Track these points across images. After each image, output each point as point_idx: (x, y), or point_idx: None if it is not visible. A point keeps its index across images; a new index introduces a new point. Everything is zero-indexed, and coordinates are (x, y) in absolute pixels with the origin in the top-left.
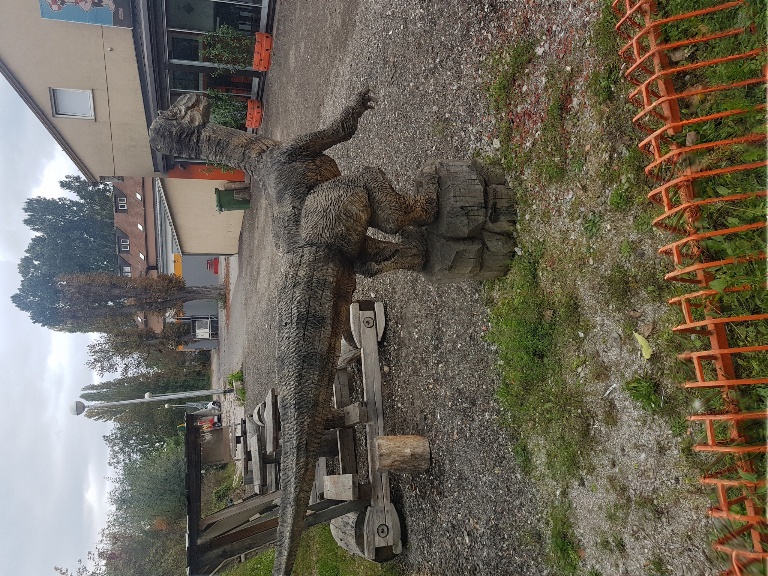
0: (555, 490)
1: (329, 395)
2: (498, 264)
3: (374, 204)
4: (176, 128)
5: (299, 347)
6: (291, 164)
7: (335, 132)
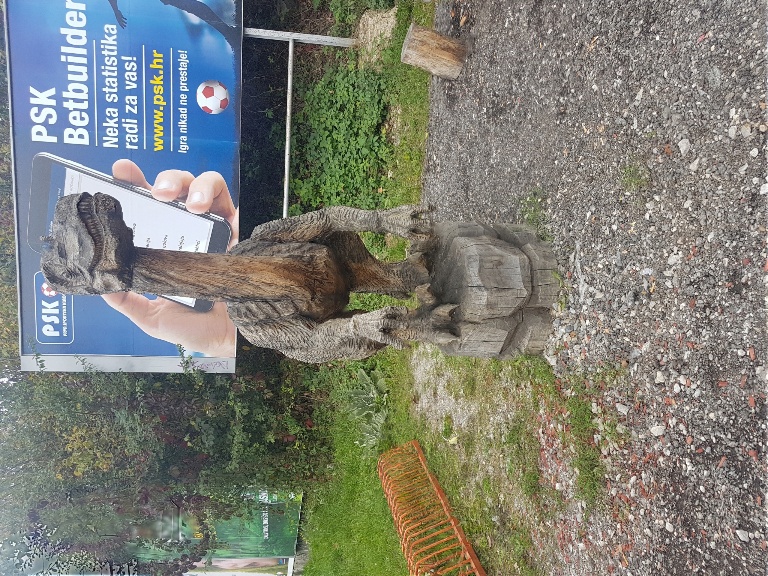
0: None
1: None
2: None
3: None
4: None
5: None
6: None
7: None
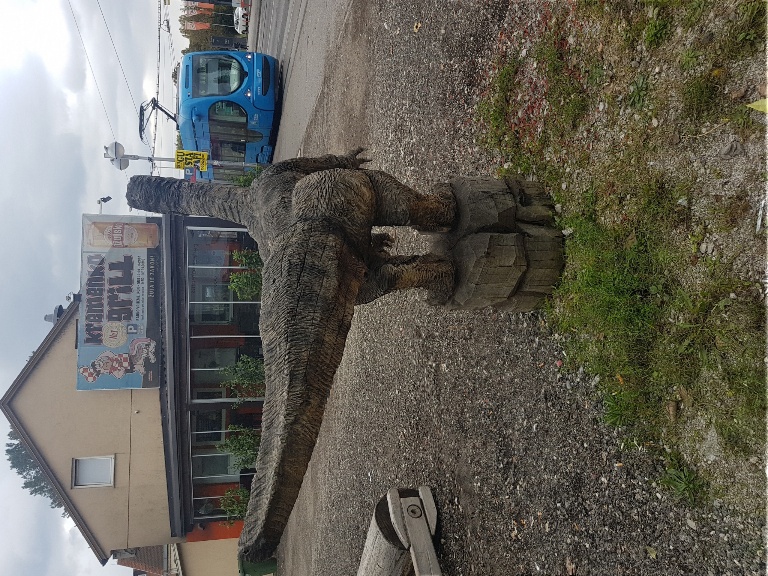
0: (761, 475)
1: (341, 343)
2: (548, 256)
3: (378, 188)
4: (156, 177)
5: (292, 289)
6: (280, 174)
7: (328, 160)
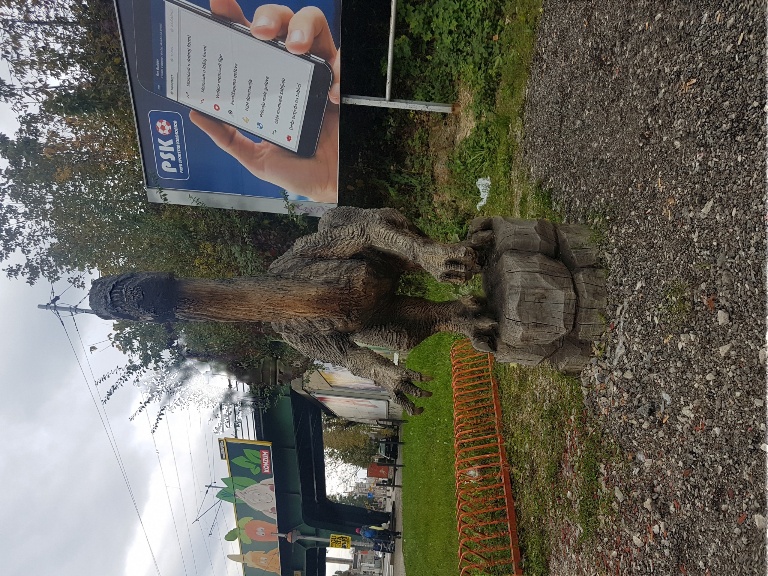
0: None
1: None
2: None
3: None
4: None
5: None
6: None
7: None
